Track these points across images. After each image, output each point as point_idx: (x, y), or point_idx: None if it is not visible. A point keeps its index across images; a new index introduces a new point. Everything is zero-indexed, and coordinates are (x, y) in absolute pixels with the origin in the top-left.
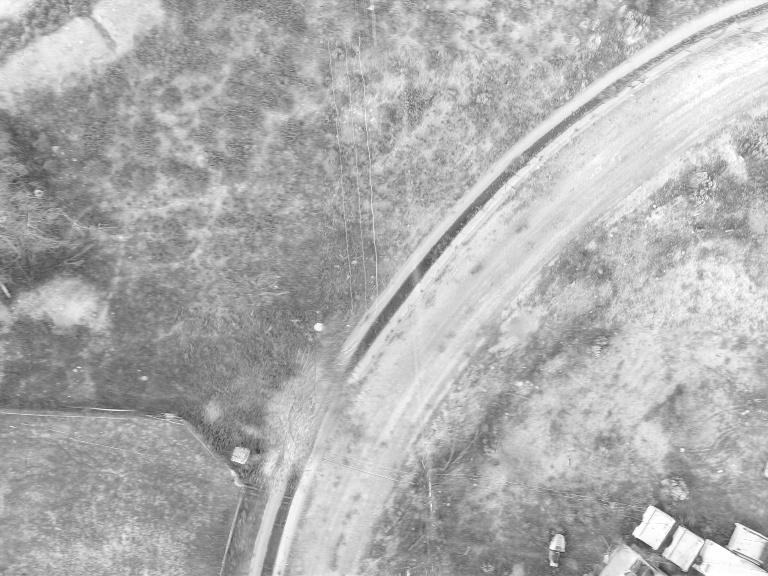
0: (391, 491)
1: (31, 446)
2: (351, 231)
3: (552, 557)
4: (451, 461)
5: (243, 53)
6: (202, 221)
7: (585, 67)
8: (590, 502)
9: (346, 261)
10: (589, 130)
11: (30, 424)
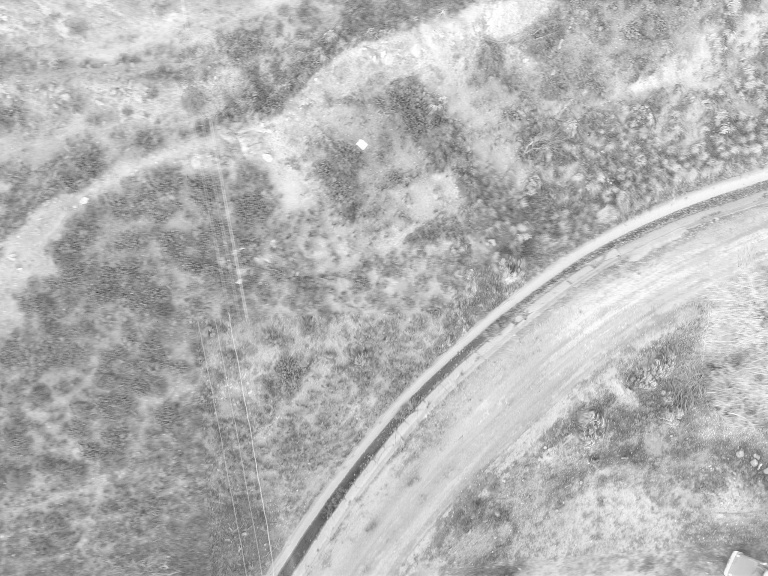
0: None
1: None
2: (238, 504)
3: None
4: None
5: (110, 344)
6: (84, 511)
7: (464, 314)
8: None
9: (236, 534)
10: (474, 374)
11: None
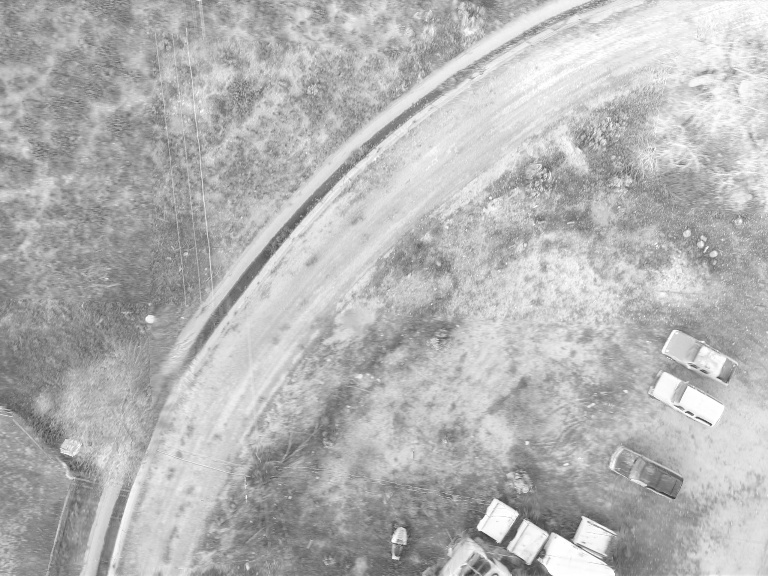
0: (225, 484)
1: None
2: (182, 223)
3: (394, 550)
4: (289, 454)
5: (67, 44)
6: (30, 213)
7: (420, 58)
8: (434, 495)
9: (177, 253)
10: (426, 122)
11: None
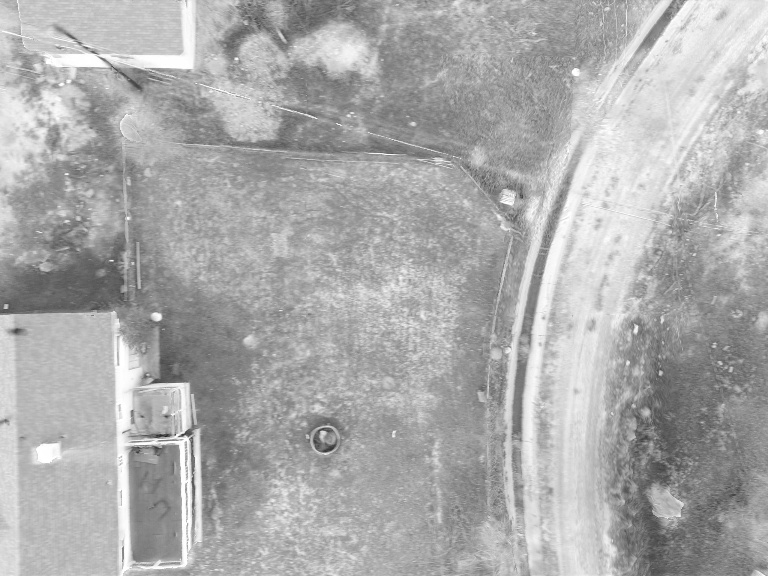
0: (650, 232)
1: (310, 190)
2: None
3: None
4: (701, 206)
5: None
6: None
7: None
8: None
9: (600, 8)
10: None
11: (308, 169)
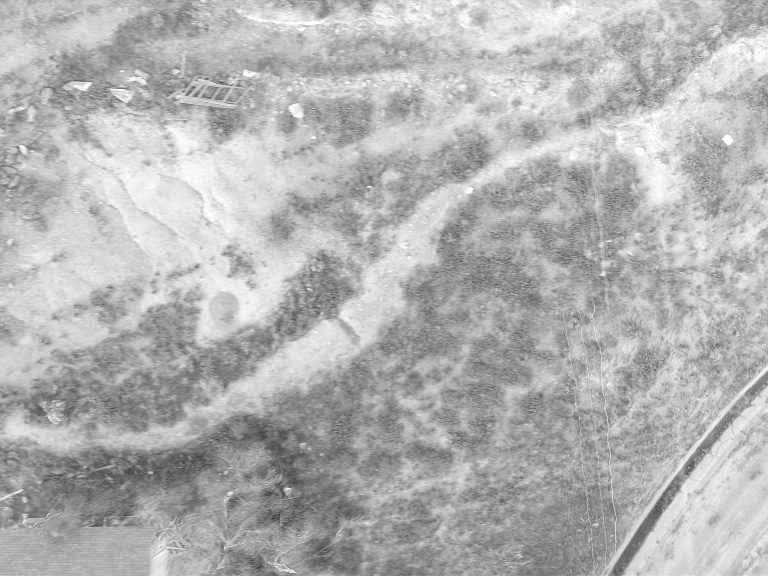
0: None
1: None
2: (591, 494)
3: None
4: None
5: (483, 333)
6: (446, 499)
7: None
8: None
9: (588, 525)
10: None
11: None
